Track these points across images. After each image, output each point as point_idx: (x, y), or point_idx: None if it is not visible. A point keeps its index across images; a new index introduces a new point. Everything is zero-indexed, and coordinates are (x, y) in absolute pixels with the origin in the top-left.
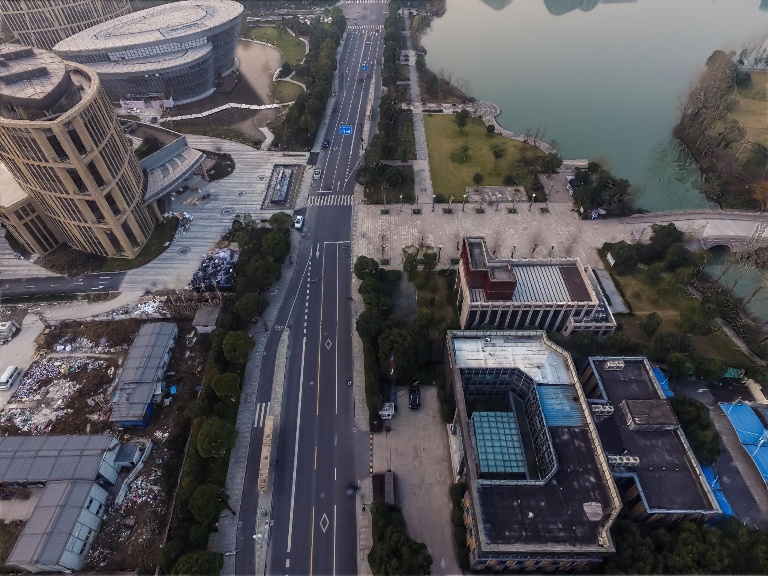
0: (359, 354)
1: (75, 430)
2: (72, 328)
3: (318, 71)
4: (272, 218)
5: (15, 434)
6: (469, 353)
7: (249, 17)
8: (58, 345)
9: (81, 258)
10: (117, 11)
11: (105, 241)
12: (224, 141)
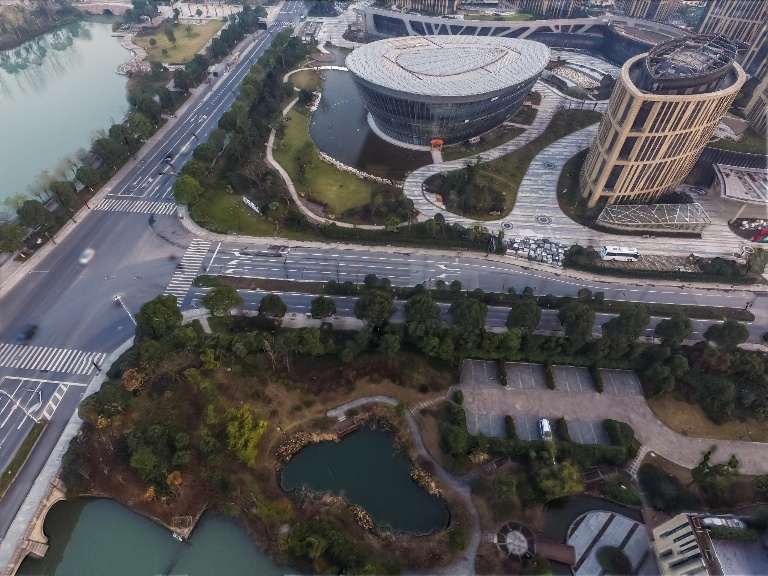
0: None
1: None
2: None
3: None
4: None
5: None
6: None
7: (396, 285)
8: None
9: None
10: None
11: None
12: None
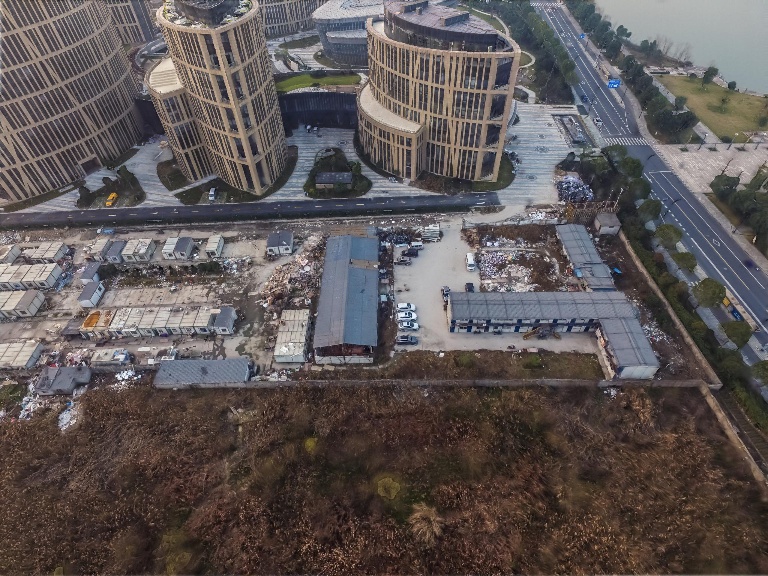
0: (750, 249)
1: None
2: None
3: (548, 38)
4: (613, 149)
5: None
6: None
7: None
8: (487, 242)
9: (450, 181)
10: None
11: (480, 165)
12: None
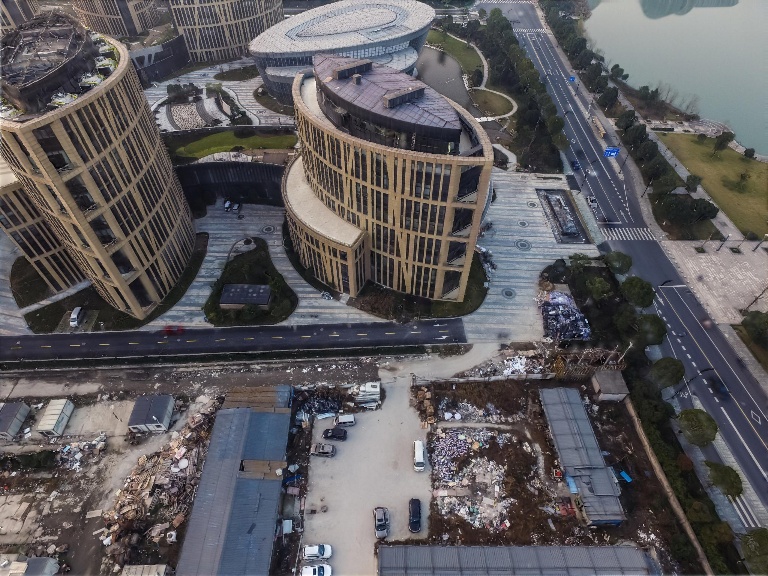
0: None
1: (537, 527)
2: (444, 389)
3: (533, 82)
4: (614, 259)
5: (472, 532)
6: None
7: None
8: (445, 412)
9: (402, 300)
10: (275, 6)
11: (440, 283)
12: None
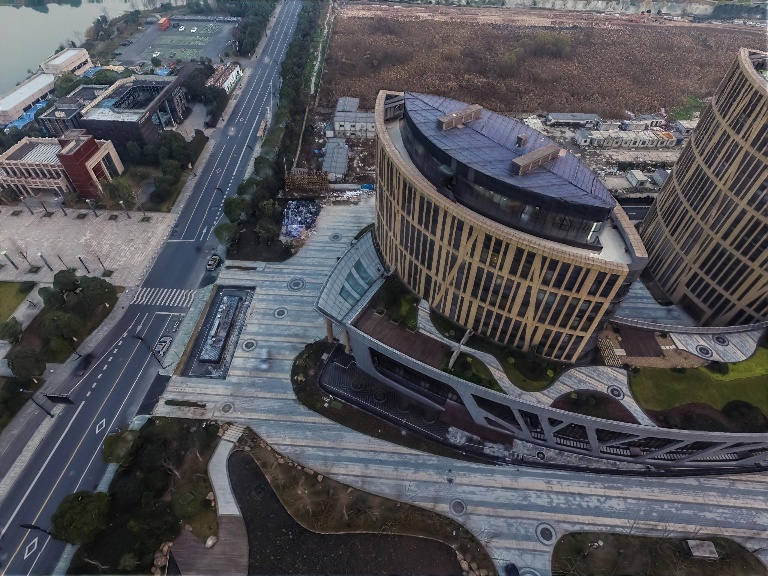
0: (200, 165)
1: None
2: None
3: None
4: (235, 225)
5: None
6: (134, 119)
7: None
8: None
9: None
10: None
11: None
12: (317, 462)
